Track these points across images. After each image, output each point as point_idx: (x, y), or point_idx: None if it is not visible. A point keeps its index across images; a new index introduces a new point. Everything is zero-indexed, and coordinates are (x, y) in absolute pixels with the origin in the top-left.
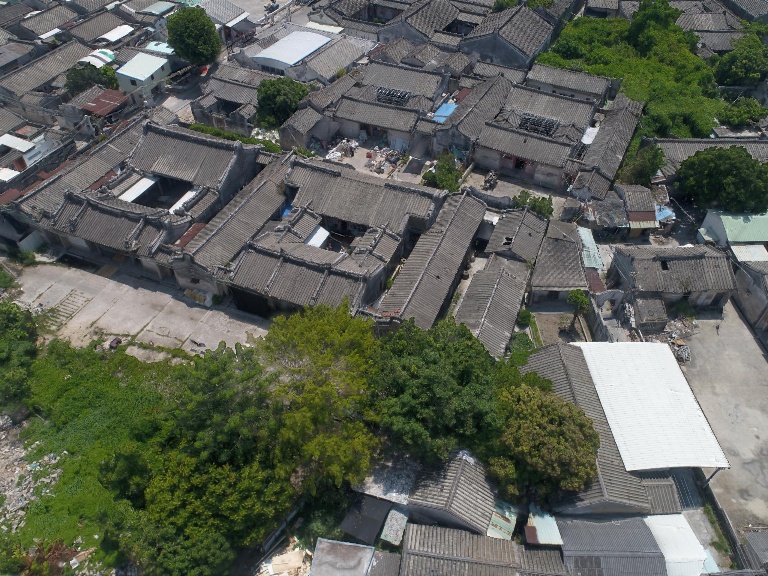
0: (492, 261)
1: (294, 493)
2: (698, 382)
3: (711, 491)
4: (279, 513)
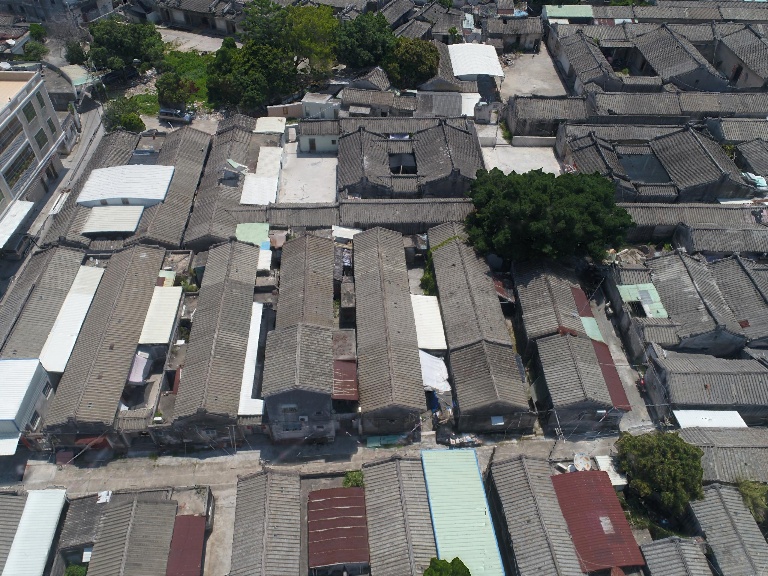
0: None
1: (297, 72)
2: (513, 72)
3: (500, 97)
4: (290, 77)
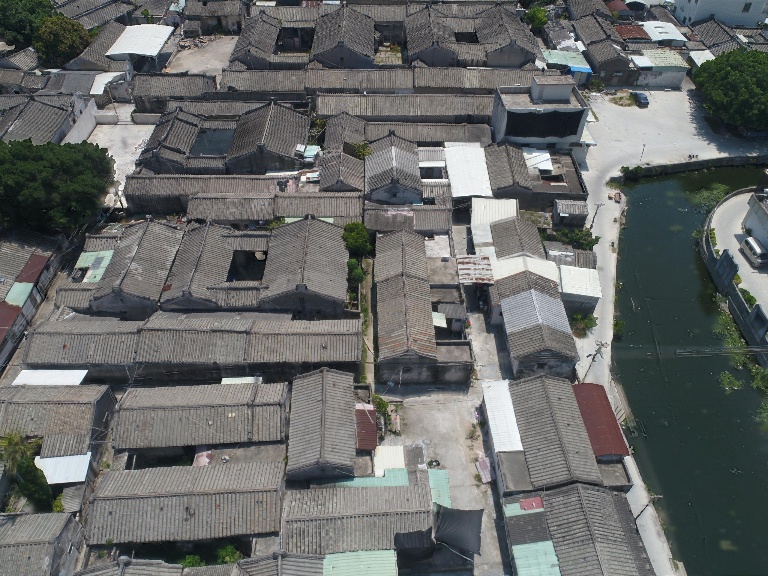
0: (117, 4)
1: None
2: (198, 53)
3: None
4: None
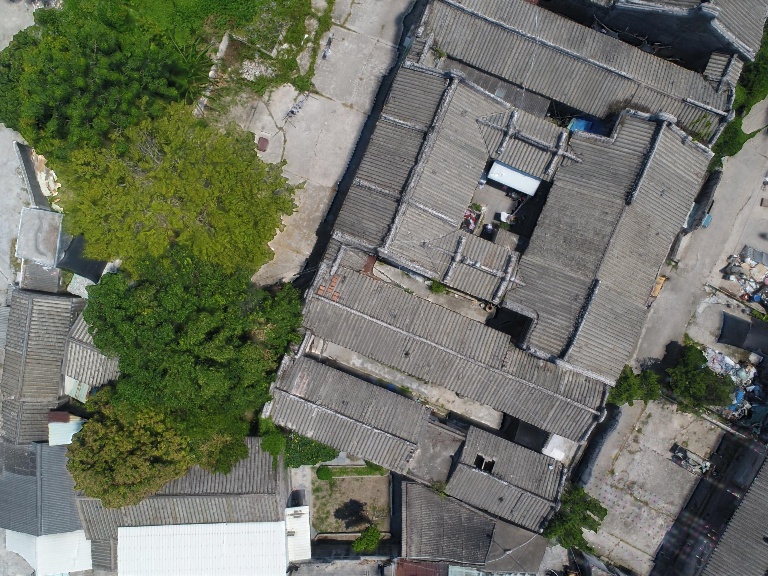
0: (449, 434)
1: None
2: None
3: None
4: None
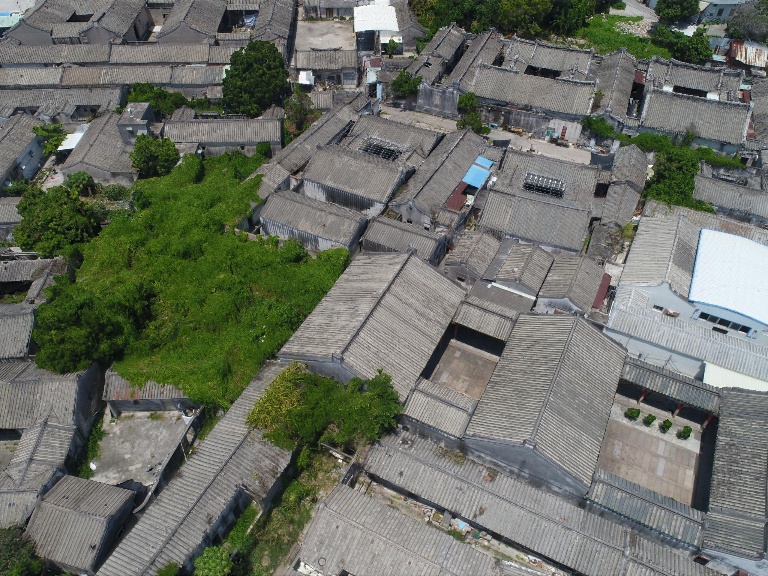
0: None
1: None
2: None
3: None
4: None
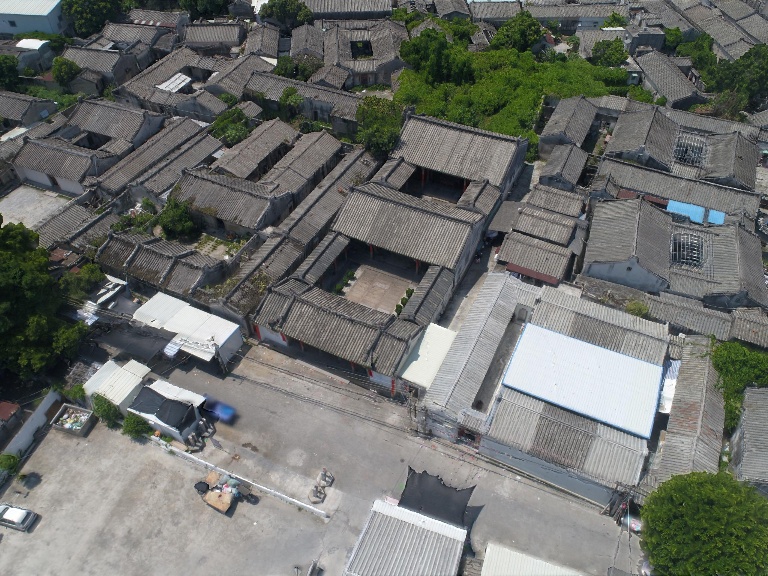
0: None
1: None
2: None
3: None
4: None
